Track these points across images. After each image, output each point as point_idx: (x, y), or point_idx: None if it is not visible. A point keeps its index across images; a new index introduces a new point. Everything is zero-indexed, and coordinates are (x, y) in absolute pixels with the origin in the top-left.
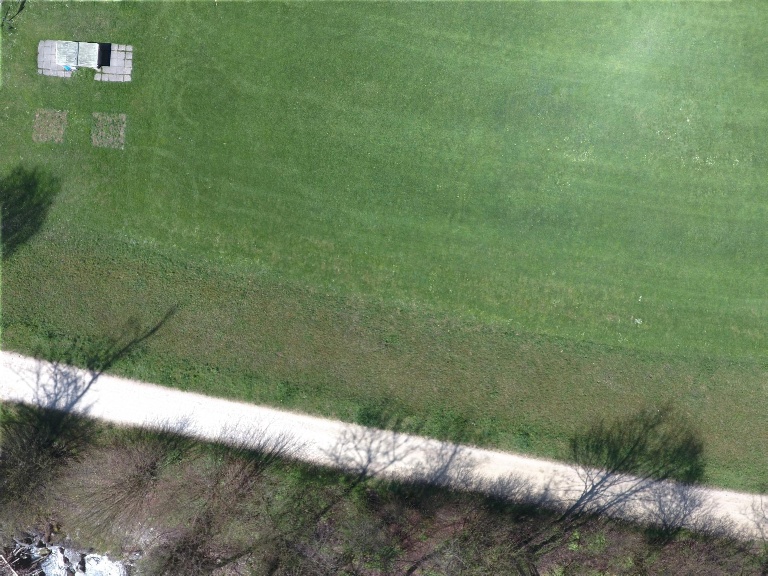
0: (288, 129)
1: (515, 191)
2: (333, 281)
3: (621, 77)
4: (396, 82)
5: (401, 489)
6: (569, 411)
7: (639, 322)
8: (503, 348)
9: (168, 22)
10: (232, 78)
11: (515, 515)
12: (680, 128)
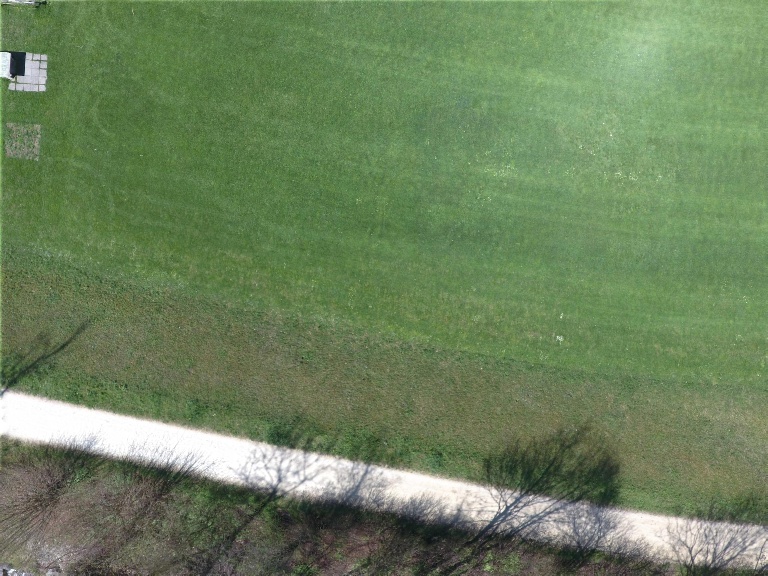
0: (206, 141)
1: (435, 206)
2: (251, 296)
3: (543, 90)
4: (315, 94)
5: (311, 509)
6: (485, 430)
7: (561, 339)
8: (422, 365)
9: (84, 31)
10: (149, 89)
11: (427, 536)
12: (603, 143)
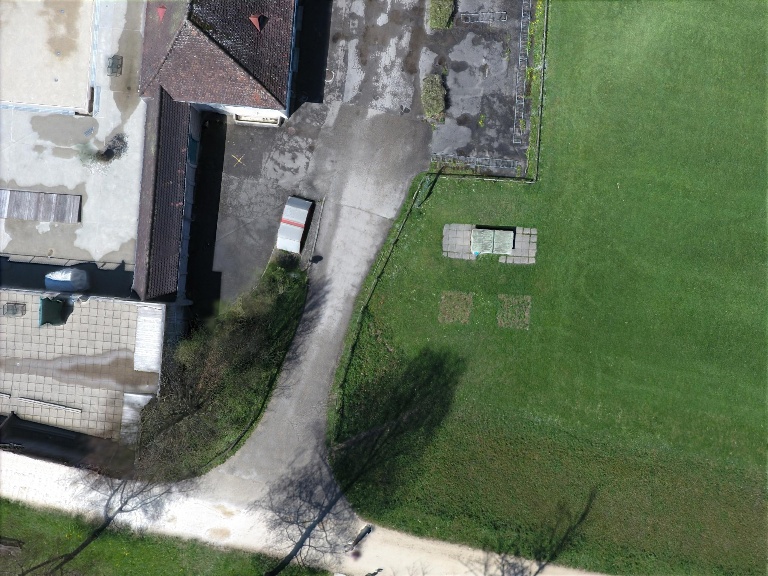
0: (688, 308)
1: None
2: (731, 454)
3: None
4: None
5: None
6: None
7: None
8: None
9: (571, 205)
10: (633, 259)
11: None
12: None
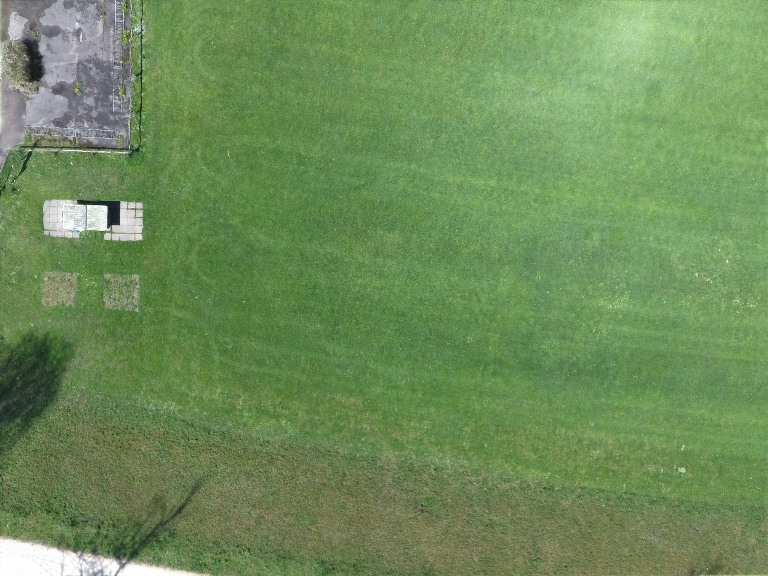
0: (310, 284)
1: (549, 341)
2: (363, 440)
3: (656, 219)
4: (421, 231)
5: None
6: (615, 575)
7: (682, 471)
8: (543, 505)
9: (179, 176)
10: (249, 232)
11: None
12: (719, 270)
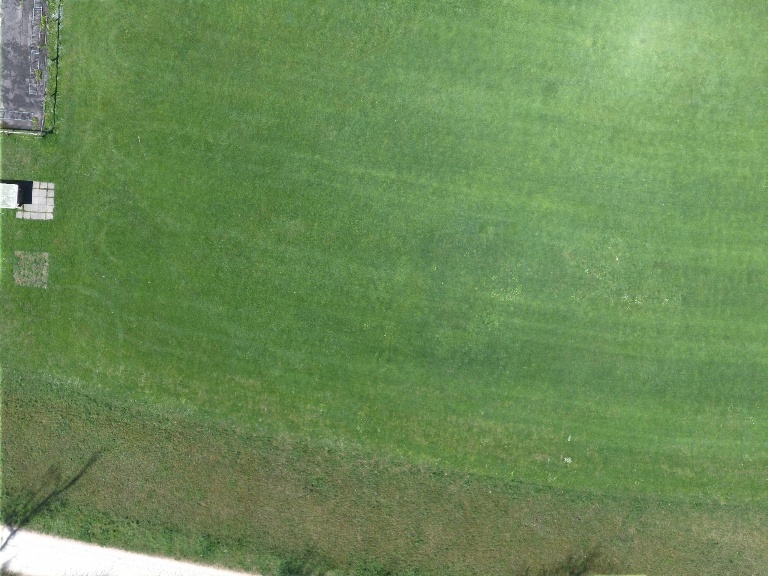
0: (213, 267)
1: (443, 330)
2: (260, 421)
3: (549, 215)
4: (322, 220)
5: None
6: (494, 559)
7: (569, 461)
8: (431, 490)
9: (90, 159)
10: (156, 215)
11: None
12: (609, 267)
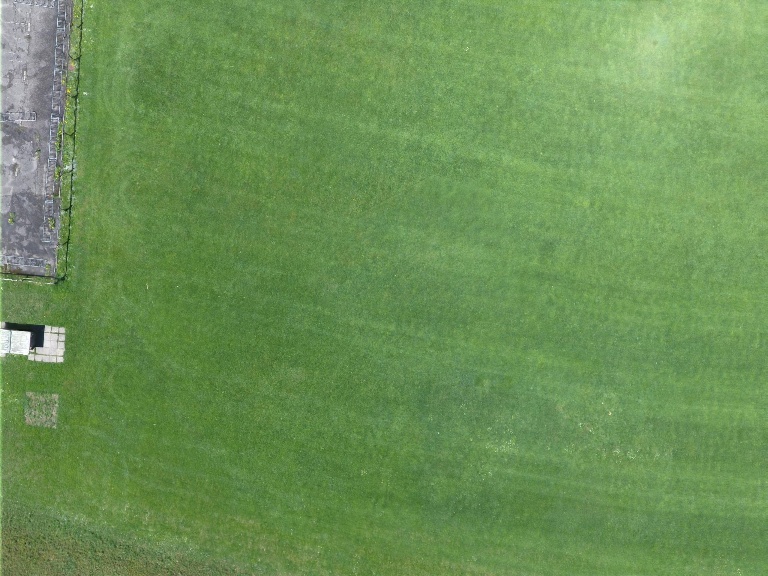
0: (217, 412)
1: (438, 479)
2: (259, 561)
3: (544, 371)
4: (323, 368)
5: None
6: None
7: None
8: None
9: (100, 305)
10: (162, 360)
11: None
12: (602, 422)
